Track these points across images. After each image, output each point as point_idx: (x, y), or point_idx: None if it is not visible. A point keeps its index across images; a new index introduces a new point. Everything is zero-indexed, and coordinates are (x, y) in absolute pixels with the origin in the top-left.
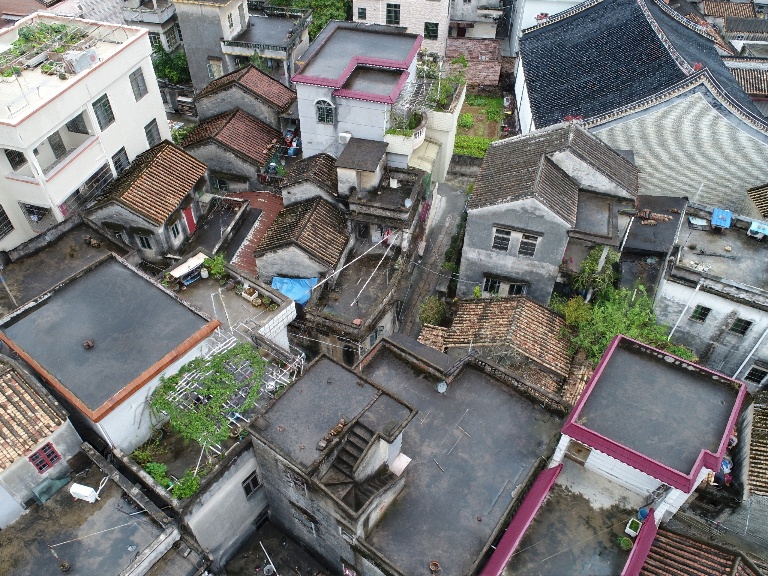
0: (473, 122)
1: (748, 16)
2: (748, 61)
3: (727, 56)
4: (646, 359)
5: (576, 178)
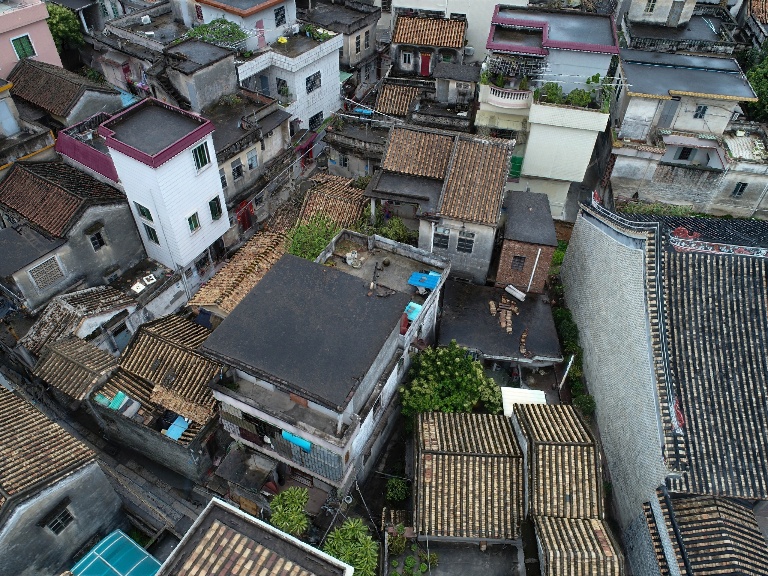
0: None
1: None
2: None
3: None
4: None
5: None
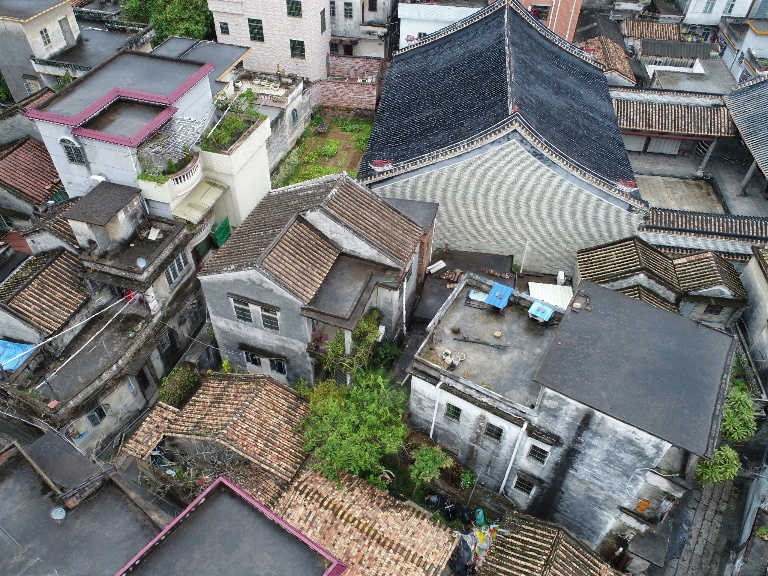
0: (335, 151)
1: (672, 38)
2: (643, 92)
3: (620, 86)
4: (245, 512)
5: (336, 241)
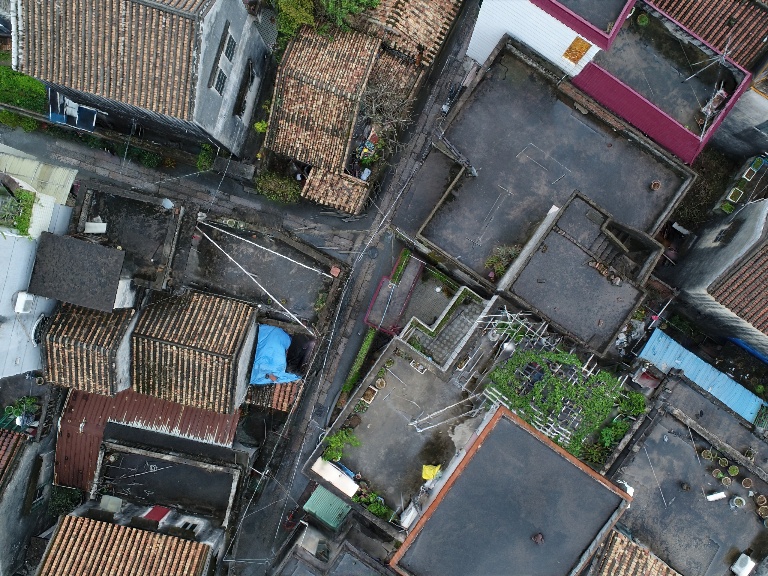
0: None
1: None
2: None
3: None
4: None
5: None
